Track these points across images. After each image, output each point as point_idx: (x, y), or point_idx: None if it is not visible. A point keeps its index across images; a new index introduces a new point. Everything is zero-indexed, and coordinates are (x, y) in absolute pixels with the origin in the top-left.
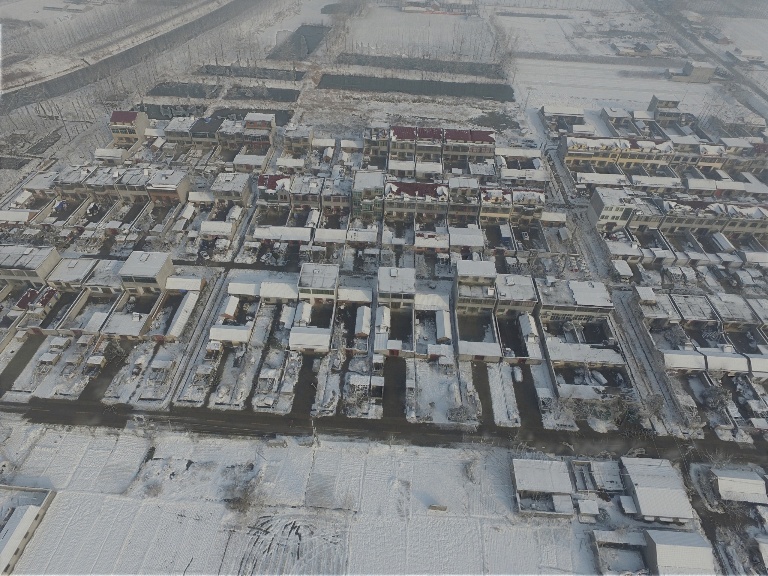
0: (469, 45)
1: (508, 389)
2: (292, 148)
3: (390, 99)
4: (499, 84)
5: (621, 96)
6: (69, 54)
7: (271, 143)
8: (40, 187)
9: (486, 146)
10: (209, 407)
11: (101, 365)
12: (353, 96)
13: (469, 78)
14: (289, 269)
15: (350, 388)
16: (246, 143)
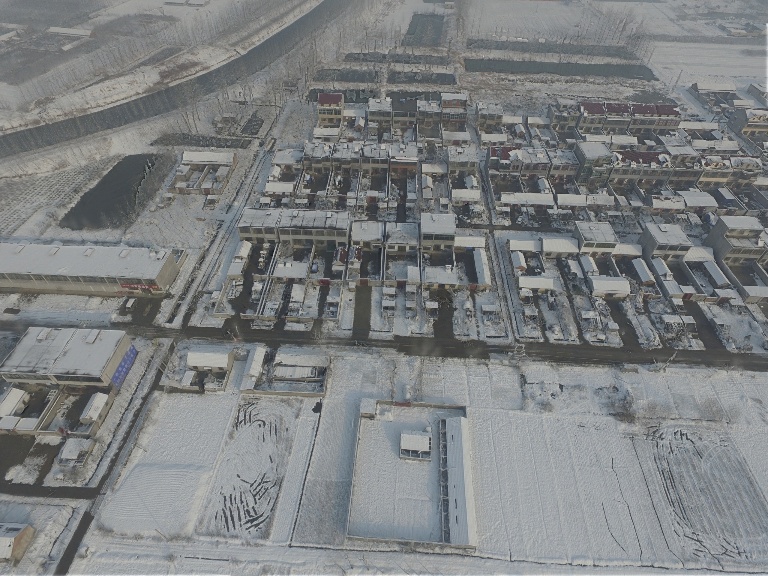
0: (596, 28)
1: None
2: (484, 125)
3: (544, 80)
4: (634, 65)
5: (756, 73)
6: (221, 45)
7: (465, 121)
8: (288, 162)
9: (673, 119)
10: (551, 342)
11: None
12: (508, 78)
13: (605, 60)
14: (546, 230)
15: (668, 325)
16: (442, 121)
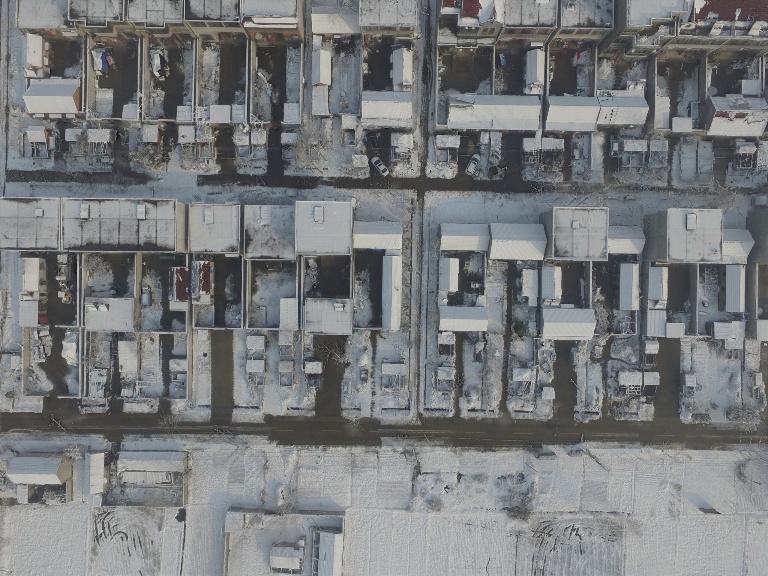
0: None
1: None
2: None
3: None
4: None
5: None
6: None
7: None
8: (48, 24)
9: None
10: (462, 417)
11: None
12: None
13: None
14: (510, 187)
15: (621, 390)
16: None
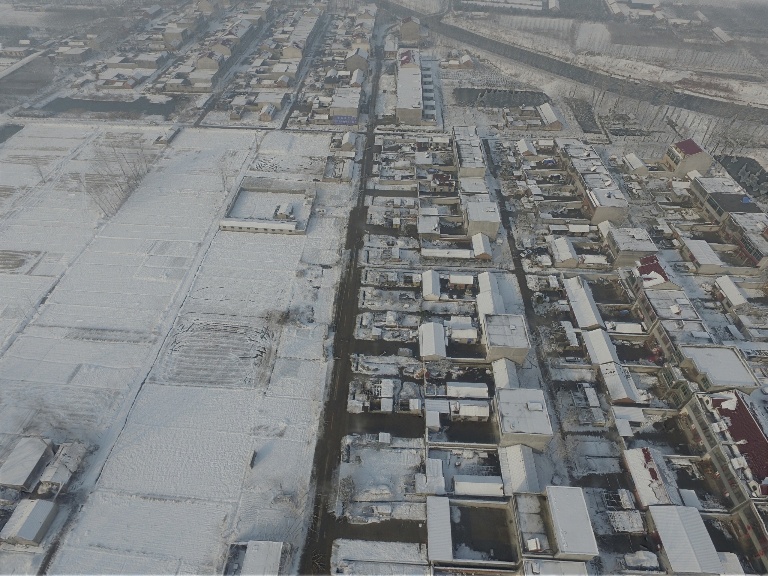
0: None
1: (386, 570)
2: None
3: None
4: None
5: None
6: None
7: (761, 266)
8: (560, 144)
9: None
10: (361, 288)
11: (394, 226)
12: None
13: None
14: (531, 318)
15: None
16: None
